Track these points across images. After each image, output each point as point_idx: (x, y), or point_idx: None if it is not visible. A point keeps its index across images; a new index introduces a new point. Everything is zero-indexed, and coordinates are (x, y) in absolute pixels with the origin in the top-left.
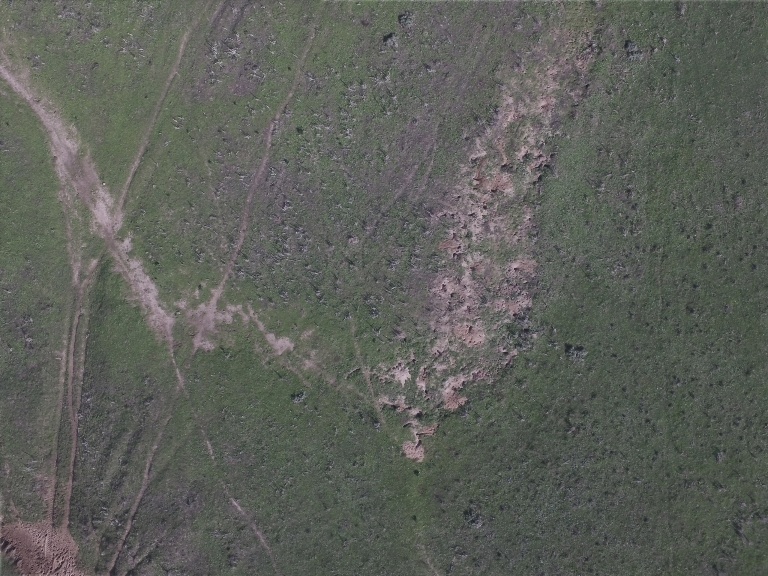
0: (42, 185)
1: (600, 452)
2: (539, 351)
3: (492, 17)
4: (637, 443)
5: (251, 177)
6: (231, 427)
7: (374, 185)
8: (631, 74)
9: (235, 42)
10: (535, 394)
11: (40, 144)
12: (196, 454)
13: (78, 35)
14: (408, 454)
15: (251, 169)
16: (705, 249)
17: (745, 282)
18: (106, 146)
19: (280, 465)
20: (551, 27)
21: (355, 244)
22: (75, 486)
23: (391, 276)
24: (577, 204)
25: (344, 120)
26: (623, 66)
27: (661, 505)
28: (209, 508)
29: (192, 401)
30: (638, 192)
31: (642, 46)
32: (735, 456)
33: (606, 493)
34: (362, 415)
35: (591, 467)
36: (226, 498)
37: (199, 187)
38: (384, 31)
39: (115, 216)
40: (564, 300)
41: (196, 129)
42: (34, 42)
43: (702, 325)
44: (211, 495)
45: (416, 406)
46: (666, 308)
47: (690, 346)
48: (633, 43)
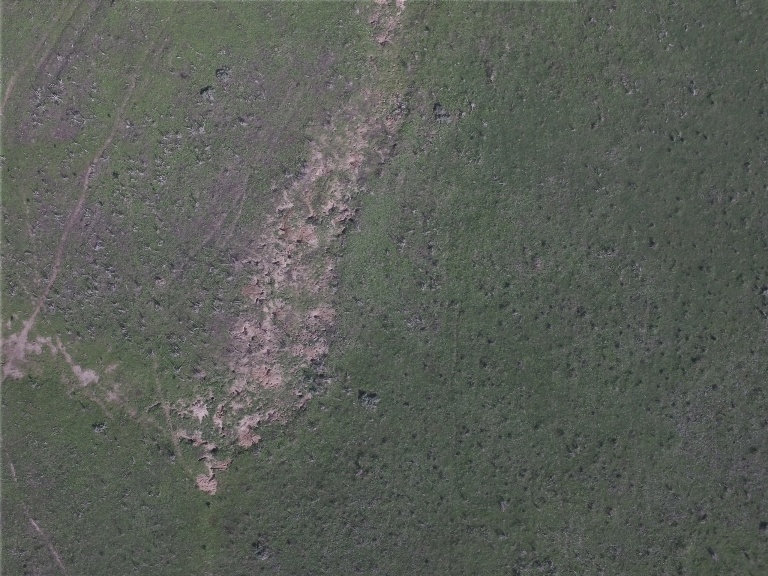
0: None
1: (387, 495)
2: (333, 396)
3: (305, 76)
4: (424, 488)
5: (66, 217)
6: (34, 452)
7: (184, 230)
8: (438, 136)
9: (59, 88)
10: (327, 436)
11: None
12: None
13: None
14: (201, 487)
15: (67, 209)
16: (501, 307)
17: (539, 340)
18: None
19: (79, 490)
20: (362, 87)
21: (162, 285)
22: None
23: (195, 317)
24: (378, 258)
25: (158, 167)
26: (430, 128)
27: (443, 548)
28: (9, 527)
29: None
30: (439, 249)
31: (450, 109)
32: (519, 506)
33: (390, 534)
34: (160, 447)
35: (378, 508)
36: (26, 518)
37: (16, 224)
38: (201, 84)
39: None
40: (360, 349)
41: (17, 169)
42: None
43: (494, 379)
44: (12, 515)
45: (212, 442)
46: (460, 361)
47: (481, 398)
48: (440, 107)
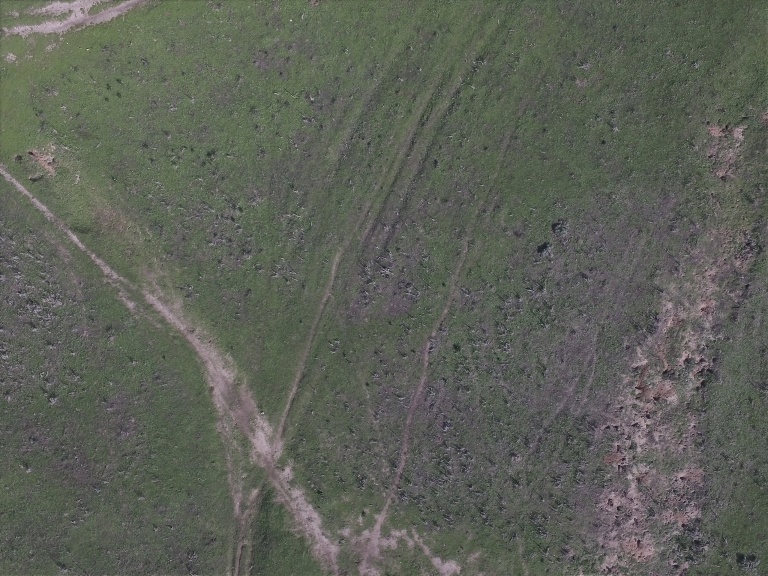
0: (201, 417)
1: None
2: (710, 563)
3: (648, 222)
4: None
5: (410, 398)
6: None
7: (534, 399)
8: None
9: (388, 260)
10: None
11: (197, 375)
12: None
13: (230, 262)
14: None
15: (409, 390)
16: None
17: None
18: (263, 374)
19: None
20: (708, 228)
21: (518, 462)
22: None
23: (556, 493)
24: (742, 409)
25: (501, 335)
26: None
27: None
28: None
29: None
30: None
31: None
32: None
33: None
34: None
35: None
36: None
37: (358, 411)
38: (538, 241)
39: (274, 444)
40: (733, 509)
41: (352, 352)
42: (187, 272)
43: None
44: None
45: None
46: None
47: None
48: None
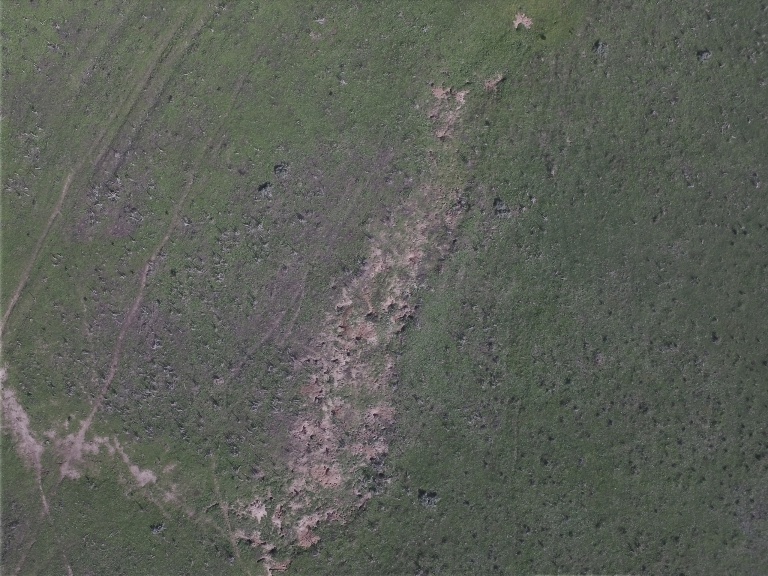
0: None
1: None
2: (392, 496)
3: (364, 172)
4: None
5: (124, 315)
6: (92, 554)
7: (242, 328)
8: (498, 231)
9: (116, 185)
10: (387, 537)
11: None
12: None
13: None
14: None
15: (125, 307)
16: (562, 403)
17: (600, 437)
18: None
19: None
20: (422, 183)
21: (220, 384)
22: None
23: (253, 417)
24: (438, 355)
25: (216, 264)
26: (491, 223)
27: None
28: None
29: (56, 527)
30: (499, 345)
31: (511, 204)
32: None
33: None
34: (218, 548)
35: None
36: None
37: (74, 323)
38: (260, 180)
39: None
40: (420, 447)
41: (74, 267)
42: None
43: (555, 477)
44: None
45: (271, 542)
46: (521, 459)
47: (542, 496)
48: (501, 202)
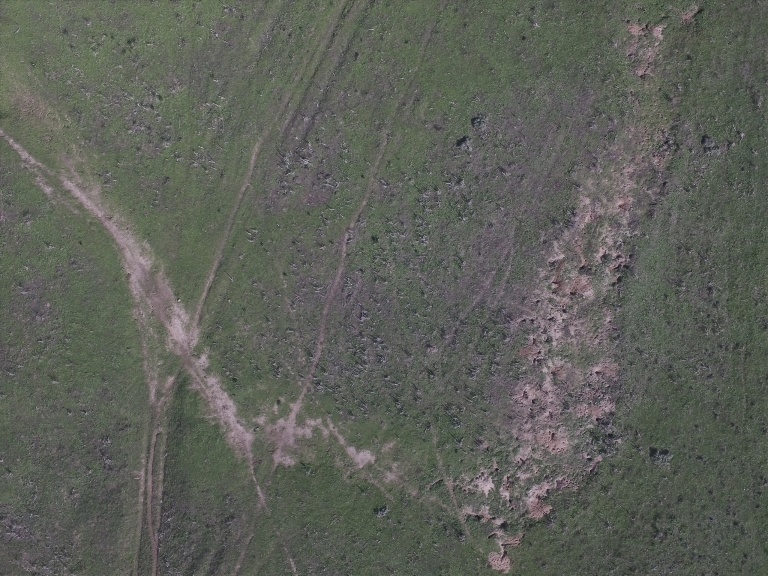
0: (117, 304)
1: (688, 557)
2: (624, 456)
3: (567, 117)
4: (725, 546)
5: (327, 288)
6: (314, 544)
7: (451, 292)
8: (709, 170)
9: (307, 151)
10: (621, 500)
11: (113, 262)
12: (279, 572)
13: (149, 150)
14: (494, 566)
15: (327, 280)
16: None
17: None
18: (180, 262)
19: None
20: (626, 125)
21: (434, 353)
22: None
23: (471, 384)
24: (658, 305)
25: (419, 227)
26: (700, 162)
27: None
28: None
29: (274, 519)
30: (719, 289)
31: (719, 141)
32: None
33: None
34: (446, 527)
35: (679, 572)
36: None
37: (275, 300)
38: (457, 135)
39: (191, 332)
40: (647, 403)
41: (270, 241)
42: (105, 159)
43: None
44: None
45: (500, 516)
46: (751, 407)
47: None
48: (710, 139)
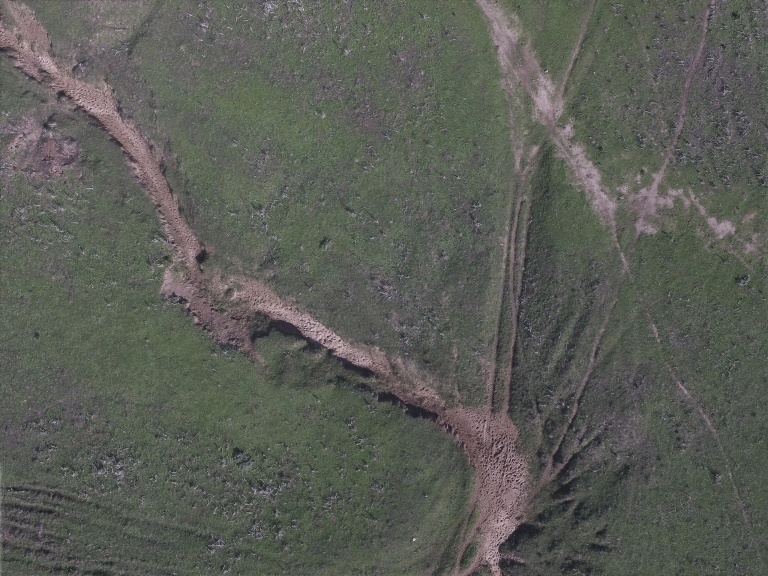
0: (487, 73)
1: None
2: None
3: None
4: None
5: (689, 62)
6: (677, 310)
7: None
8: None
9: None
10: None
11: (483, 33)
12: (643, 337)
13: None
14: None
15: (689, 54)
16: None
17: None
18: (547, 34)
19: (725, 348)
20: None
21: None
22: (516, 371)
23: None
24: None
25: None
26: None
27: None
28: (657, 391)
29: (638, 284)
30: None
31: None
32: None
33: None
34: None
35: None
36: (673, 381)
37: (639, 73)
38: None
39: (556, 103)
40: None
41: (634, 16)
42: None
43: None
44: (658, 378)
45: None
46: None
47: None
48: None
